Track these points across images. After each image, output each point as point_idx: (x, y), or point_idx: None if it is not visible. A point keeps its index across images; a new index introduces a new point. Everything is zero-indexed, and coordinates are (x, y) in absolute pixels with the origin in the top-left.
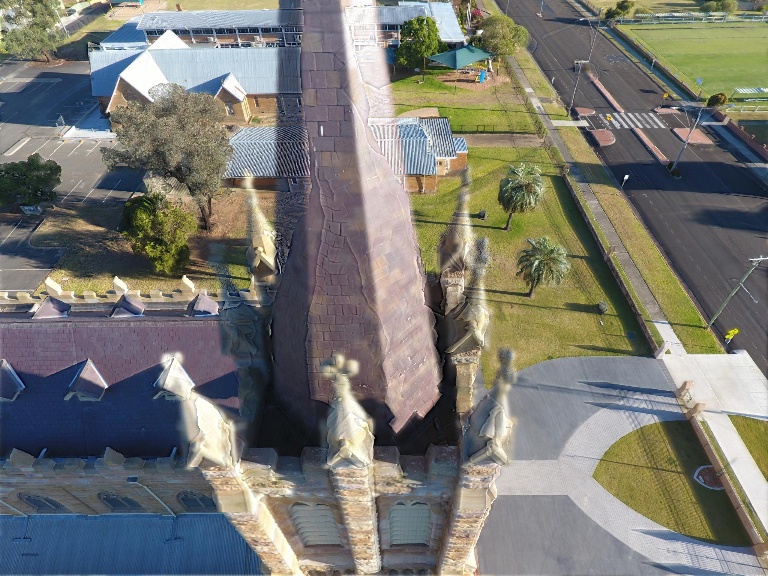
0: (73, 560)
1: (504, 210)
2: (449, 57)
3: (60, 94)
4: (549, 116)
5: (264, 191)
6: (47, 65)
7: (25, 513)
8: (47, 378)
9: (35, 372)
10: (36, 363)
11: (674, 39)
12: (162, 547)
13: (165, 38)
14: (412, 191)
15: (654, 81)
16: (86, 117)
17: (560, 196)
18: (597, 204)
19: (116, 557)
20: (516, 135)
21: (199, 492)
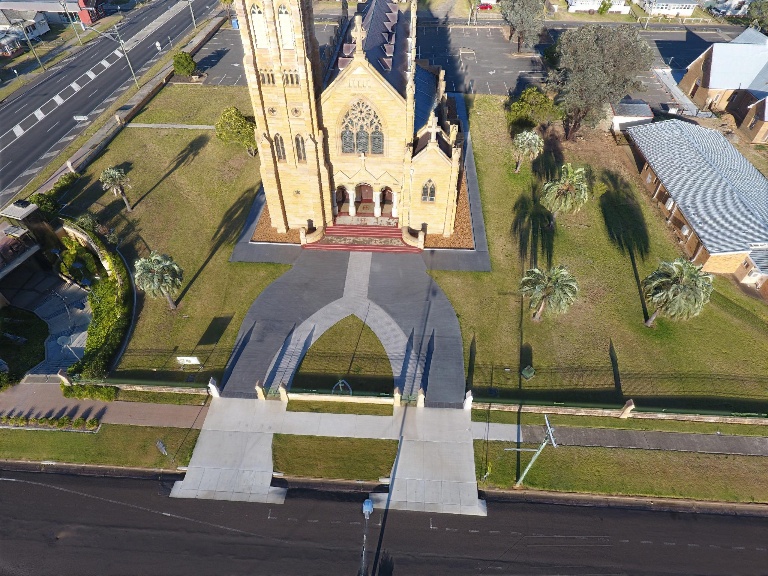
0: None
1: None
2: None
3: None
4: None
5: (634, 161)
6: None
7: None
8: None
9: None
10: None
11: None
12: None
13: None
14: (687, 253)
15: None
16: None
17: (762, 402)
18: (767, 451)
19: None
20: None
21: None
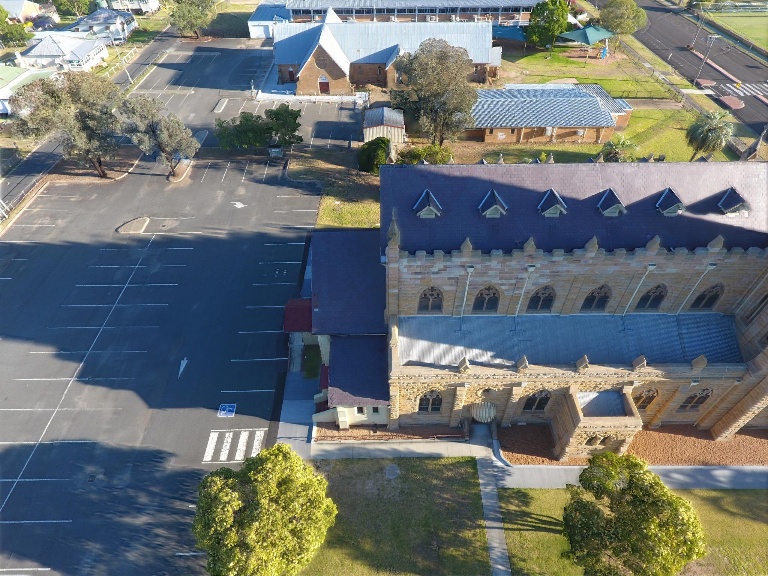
0: (557, 344)
1: (695, 150)
2: (580, 34)
3: (228, 65)
4: (677, 86)
5: (461, 141)
6: (198, 41)
7: (518, 313)
8: (582, 201)
9: (574, 197)
10: (574, 191)
11: (757, 25)
12: (619, 335)
13: (330, 14)
14: (589, 142)
15: (755, 59)
16: (265, 83)
17: None
18: None
19: (588, 342)
20: (656, 100)
21: (670, 285)
